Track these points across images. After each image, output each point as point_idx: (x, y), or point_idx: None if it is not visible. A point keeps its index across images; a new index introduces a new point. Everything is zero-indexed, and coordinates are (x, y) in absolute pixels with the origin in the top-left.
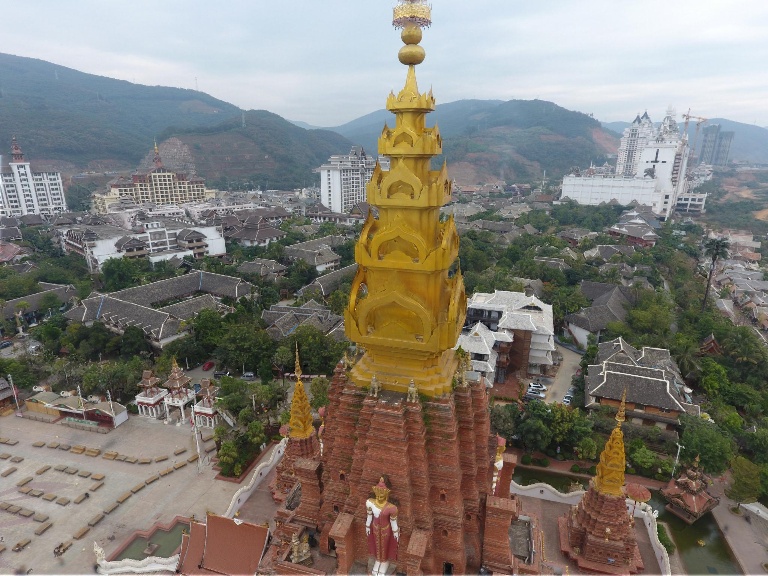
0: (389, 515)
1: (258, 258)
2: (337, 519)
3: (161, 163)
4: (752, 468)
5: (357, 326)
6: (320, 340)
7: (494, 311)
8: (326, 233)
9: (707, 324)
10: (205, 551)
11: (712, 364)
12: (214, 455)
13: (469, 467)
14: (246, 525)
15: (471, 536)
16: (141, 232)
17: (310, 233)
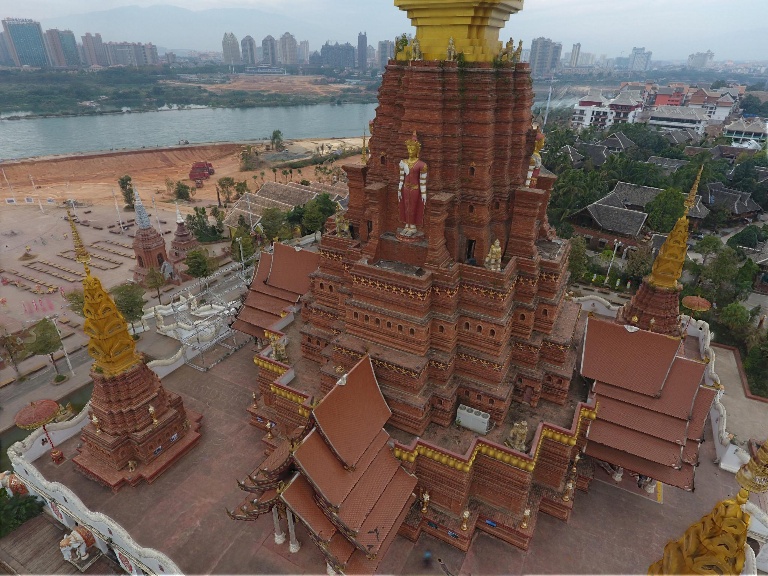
0: None
1: None
2: None
3: None
4: None
5: None
6: None
7: None
8: None
9: None
10: None
11: None
12: None
13: None
14: None
15: None
16: None
17: None
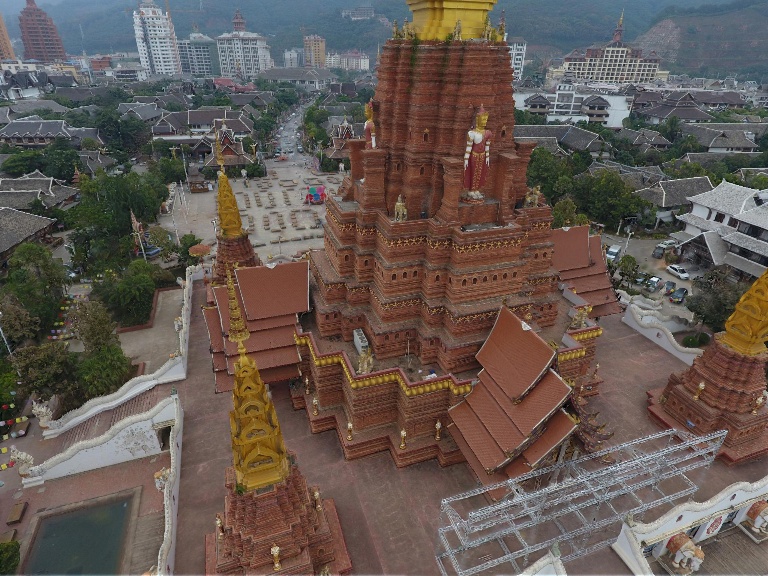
0: None
1: (644, 128)
2: None
3: (620, 37)
4: None
5: None
6: (617, 189)
7: None
8: (767, 122)
9: None
10: None
11: None
12: None
13: (441, 121)
14: None
15: (433, 190)
16: (552, 92)
17: None
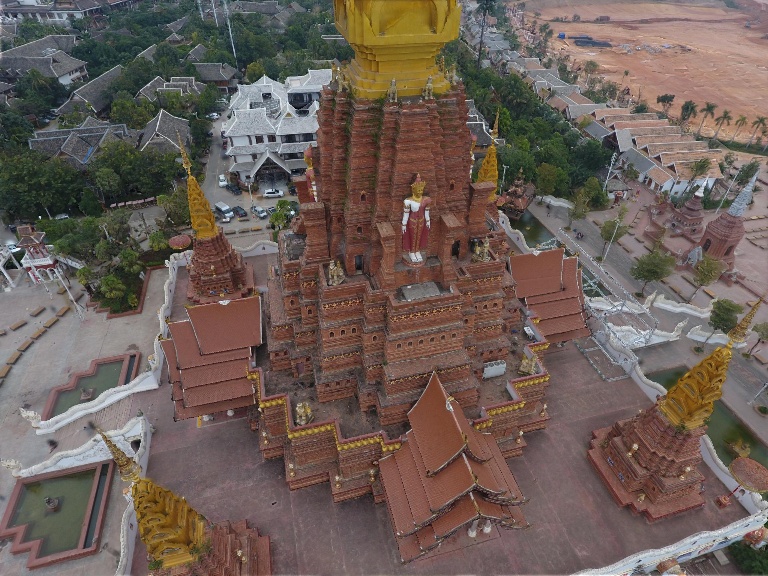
0: (425, 207)
1: None
2: (379, 227)
3: None
4: (551, 168)
5: (370, 25)
6: None
7: (315, 93)
8: (39, 33)
9: (487, 78)
10: (199, 341)
11: (500, 108)
12: (87, 301)
13: None
14: (234, 302)
15: None
16: None
17: (7, 38)
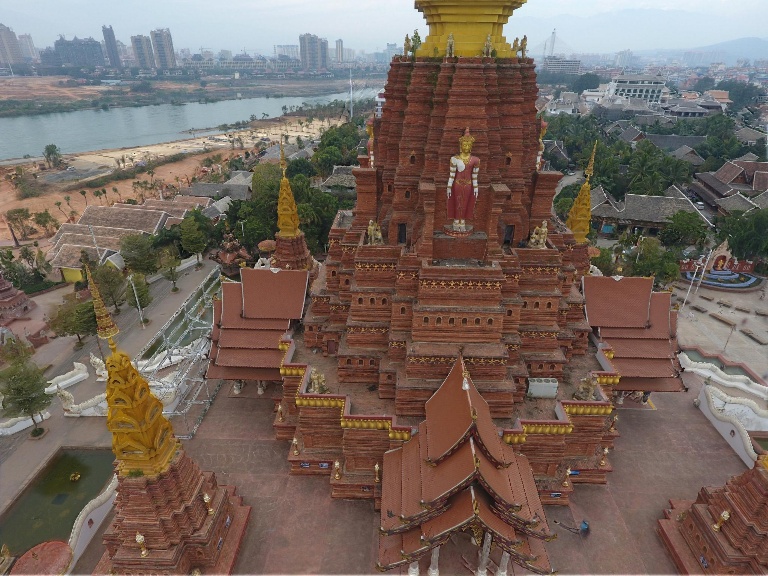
0: None
1: None
2: None
3: None
4: None
5: None
6: None
7: None
8: None
9: None
10: None
11: None
12: None
13: None
14: None
15: None
16: None
17: None
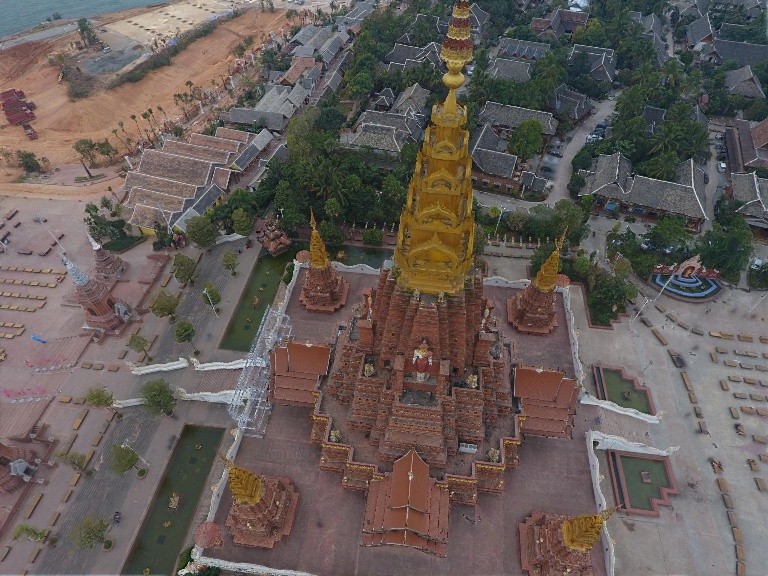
0: None
1: None
2: None
3: None
4: None
5: None
6: None
7: None
8: None
9: None
10: None
11: None
12: None
13: None
14: None
15: None
16: None
17: None
